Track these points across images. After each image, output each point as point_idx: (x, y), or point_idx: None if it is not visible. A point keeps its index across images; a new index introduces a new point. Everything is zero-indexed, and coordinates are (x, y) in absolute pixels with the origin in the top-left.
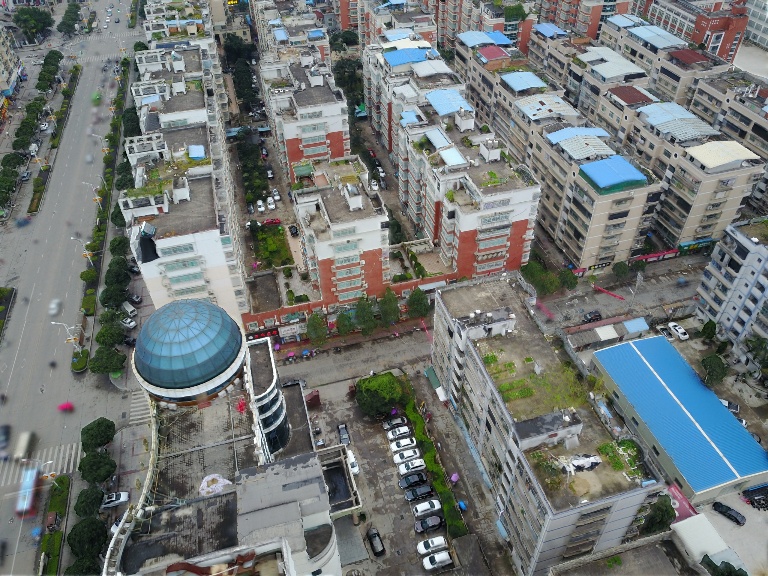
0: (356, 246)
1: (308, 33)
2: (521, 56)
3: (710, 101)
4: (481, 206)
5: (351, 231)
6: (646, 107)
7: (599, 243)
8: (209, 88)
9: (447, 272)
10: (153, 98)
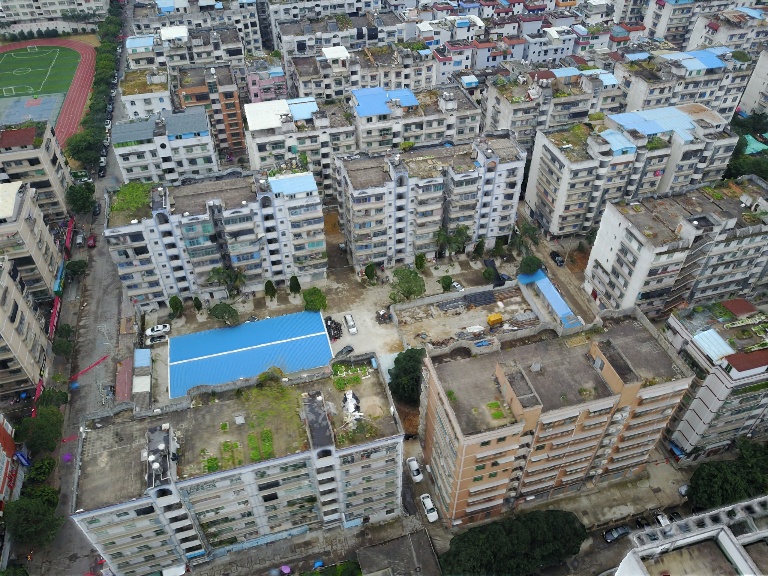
0: None
1: None
2: None
3: None
4: None
5: None
6: None
7: (25, 349)
8: None
9: None
10: None
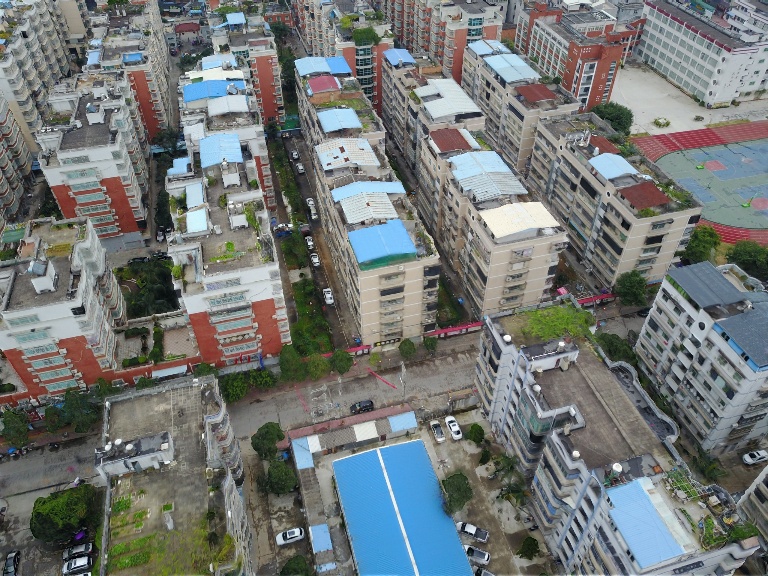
0: (46, 335)
1: (124, 57)
2: (357, 87)
3: (547, 146)
4: (204, 287)
5: (33, 319)
6: (458, 157)
7: (378, 319)
8: None
9: (192, 354)
10: None
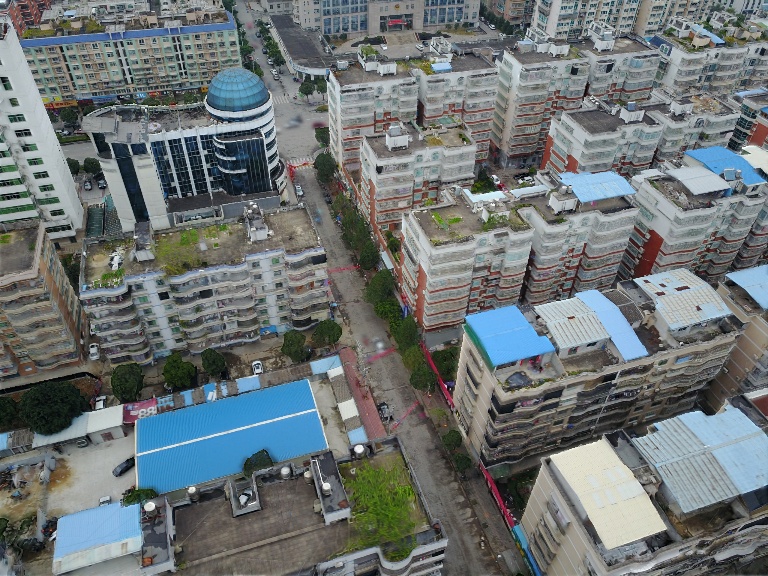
0: None
1: None
2: None
3: None
4: None
5: None
6: (743, 417)
7: None
8: (574, 66)
9: None
10: (527, 42)
